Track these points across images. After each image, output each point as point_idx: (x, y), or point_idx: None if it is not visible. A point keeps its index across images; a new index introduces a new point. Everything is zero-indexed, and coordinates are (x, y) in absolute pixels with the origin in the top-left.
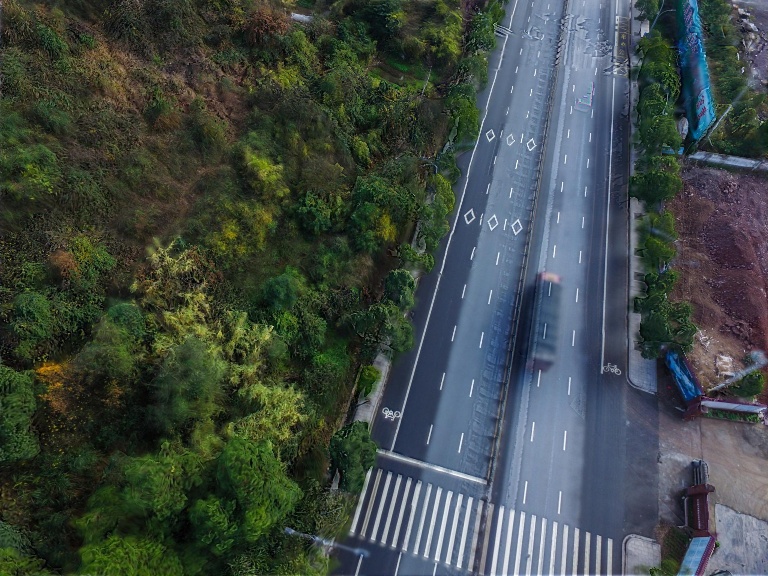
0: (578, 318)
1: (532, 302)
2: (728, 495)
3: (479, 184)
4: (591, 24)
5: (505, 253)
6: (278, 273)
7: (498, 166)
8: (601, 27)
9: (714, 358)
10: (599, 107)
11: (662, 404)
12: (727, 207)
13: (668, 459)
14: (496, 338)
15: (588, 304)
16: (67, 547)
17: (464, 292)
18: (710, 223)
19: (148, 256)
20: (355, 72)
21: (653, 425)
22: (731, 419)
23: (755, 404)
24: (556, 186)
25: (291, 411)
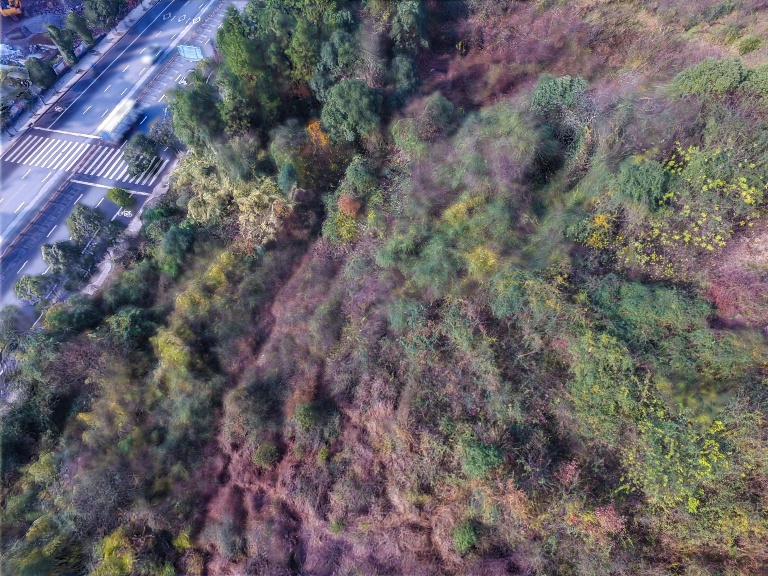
0: None
1: None
2: None
3: None
4: None
5: None
6: (185, 269)
7: None
8: None
9: None
10: None
11: None
12: None
13: None
14: (8, 269)
15: None
16: (312, 116)
17: None
18: None
19: (304, 256)
20: None
21: None
22: None
23: None
24: None
25: (179, 170)
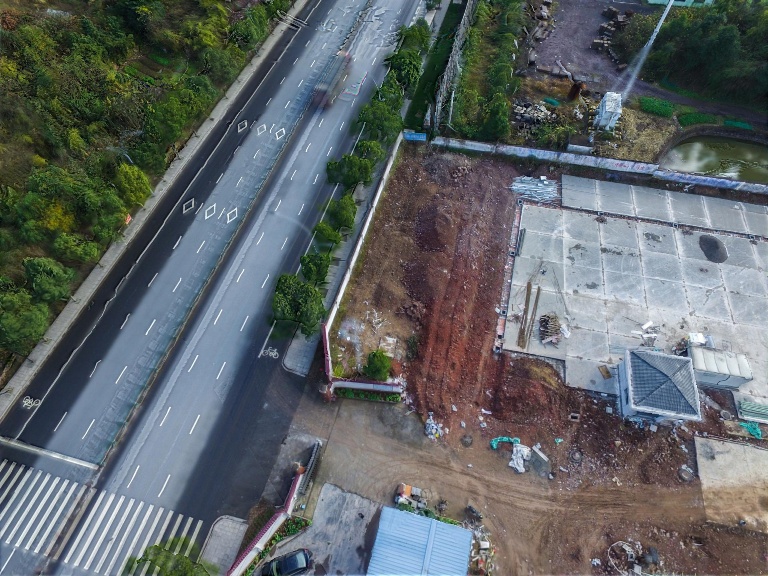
0: (257, 303)
1: (217, 289)
2: (340, 474)
3: (212, 174)
4: (389, 15)
5: (209, 241)
6: None
7: (238, 156)
8: (398, 18)
9: (379, 340)
10: (363, 96)
11: (309, 386)
12: (451, 191)
13: (293, 440)
14: (166, 325)
15: (273, 289)
16: None
17: (152, 280)
18: (425, 207)
19: None
20: (89, 65)
21: (291, 407)
22: (370, 399)
23: (386, 383)
24: (287, 174)
25: None
